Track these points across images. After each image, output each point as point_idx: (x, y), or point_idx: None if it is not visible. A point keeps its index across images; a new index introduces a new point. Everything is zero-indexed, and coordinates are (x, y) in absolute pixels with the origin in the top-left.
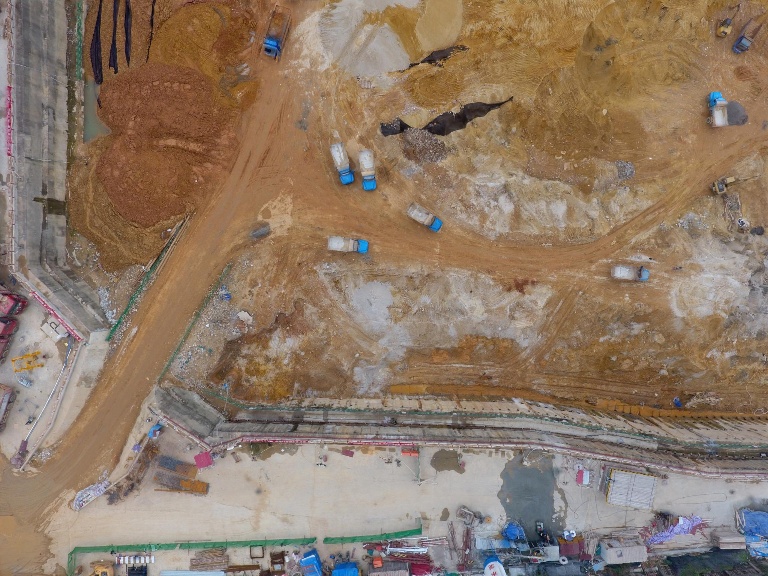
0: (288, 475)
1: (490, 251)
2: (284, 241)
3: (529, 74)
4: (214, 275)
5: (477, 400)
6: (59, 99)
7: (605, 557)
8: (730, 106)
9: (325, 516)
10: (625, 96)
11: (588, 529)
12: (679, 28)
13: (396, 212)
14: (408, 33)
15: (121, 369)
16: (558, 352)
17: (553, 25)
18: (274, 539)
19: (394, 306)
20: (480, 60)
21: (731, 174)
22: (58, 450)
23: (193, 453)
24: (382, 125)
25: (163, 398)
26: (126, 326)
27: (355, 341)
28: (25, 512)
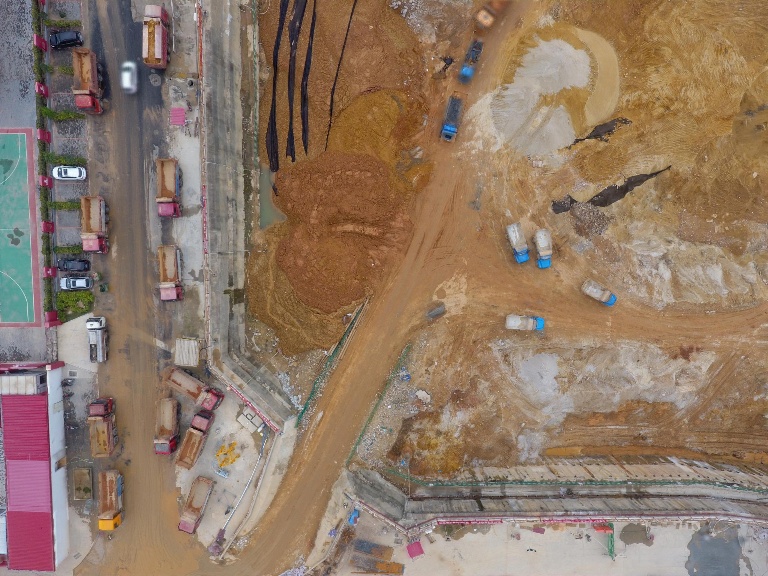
0: (481, 553)
1: (657, 321)
2: (459, 320)
3: (688, 143)
4: (394, 357)
5: (639, 463)
6: (239, 189)
7: None
8: None
9: None
10: None
11: None
12: None
13: (568, 288)
14: (578, 111)
15: (309, 454)
16: (715, 413)
17: (709, 94)
18: None
19: (560, 376)
20: (643, 133)
21: None
22: (254, 537)
23: (388, 536)
24: (553, 203)
25: (354, 482)
26: (312, 411)
27: (521, 411)
28: None
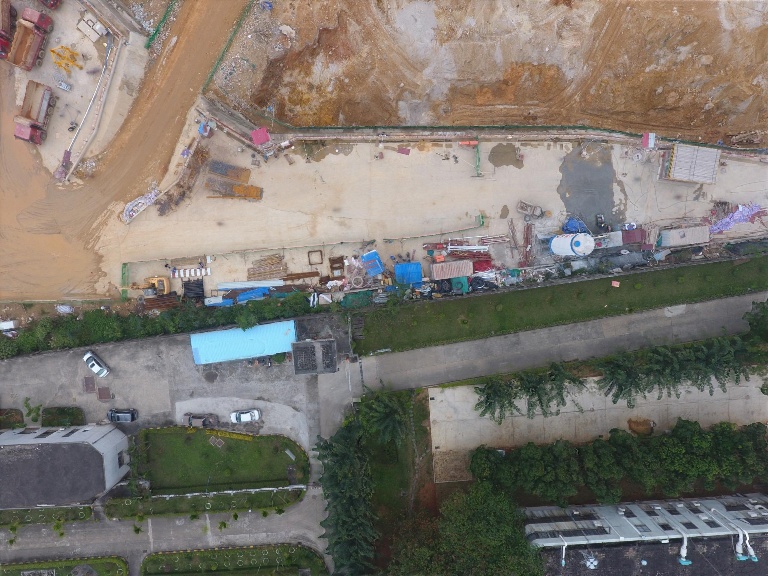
0: (344, 176)
1: None
2: None
3: None
4: None
5: None
6: None
7: (668, 241)
8: None
9: (383, 218)
10: None
11: (648, 221)
12: None
13: None
14: None
15: (163, 80)
16: (604, 82)
17: None
18: (332, 243)
19: (438, 29)
20: None
21: None
22: (103, 161)
23: (245, 157)
24: None
25: (209, 104)
26: (165, 35)
27: (399, 69)
28: (73, 228)
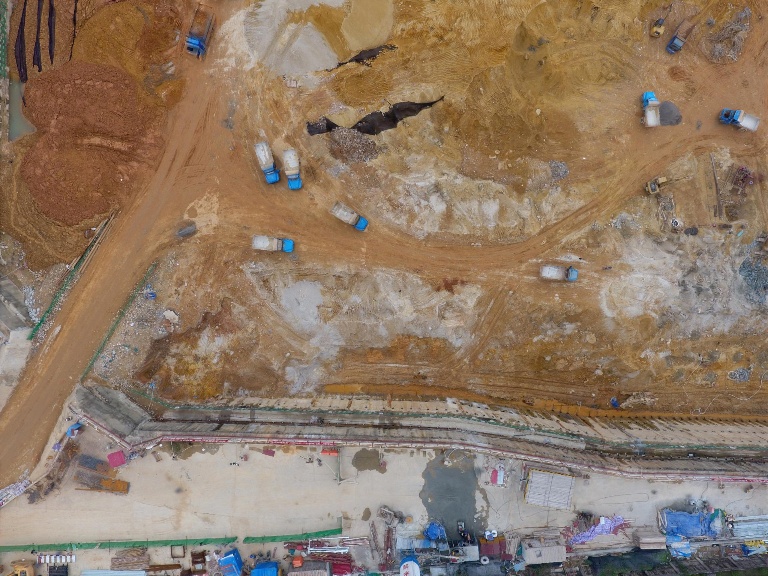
0: (209, 474)
1: (418, 251)
2: (210, 240)
3: (459, 74)
4: (139, 274)
5: (409, 400)
6: None
7: (525, 557)
8: (664, 106)
9: (246, 515)
10: (558, 96)
11: (510, 529)
12: (612, 28)
13: (323, 211)
14: (334, 32)
15: (44, 368)
16: (491, 352)
17: (484, 25)
18: (195, 538)
19: (324, 305)
20: (409, 59)
21: (665, 174)
22: None
23: (113, 452)
24: (308, 124)
25: (85, 397)
26: (49, 325)
27: (285, 340)
28: None
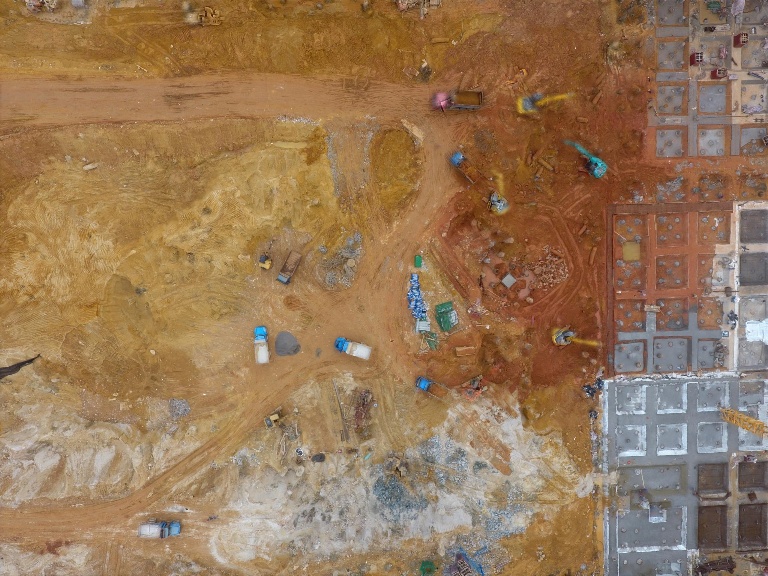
0: None
1: (14, 519)
2: None
3: (50, 333)
4: None
5: None
6: None
7: None
8: (279, 338)
9: None
10: (171, 335)
11: None
12: (214, 268)
13: None
14: None
15: None
16: None
17: (73, 280)
18: None
19: None
20: None
21: (289, 403)
22: None
23: None
24: None
25: None
26: None
27: None
28: None
